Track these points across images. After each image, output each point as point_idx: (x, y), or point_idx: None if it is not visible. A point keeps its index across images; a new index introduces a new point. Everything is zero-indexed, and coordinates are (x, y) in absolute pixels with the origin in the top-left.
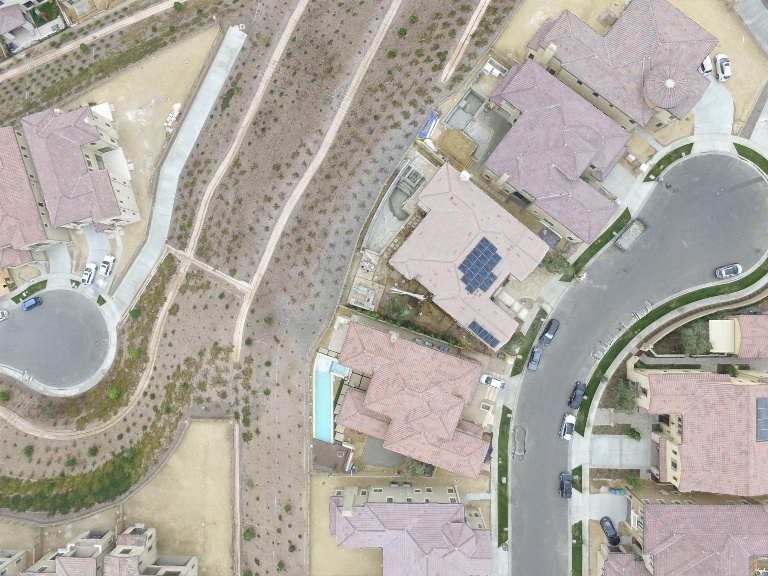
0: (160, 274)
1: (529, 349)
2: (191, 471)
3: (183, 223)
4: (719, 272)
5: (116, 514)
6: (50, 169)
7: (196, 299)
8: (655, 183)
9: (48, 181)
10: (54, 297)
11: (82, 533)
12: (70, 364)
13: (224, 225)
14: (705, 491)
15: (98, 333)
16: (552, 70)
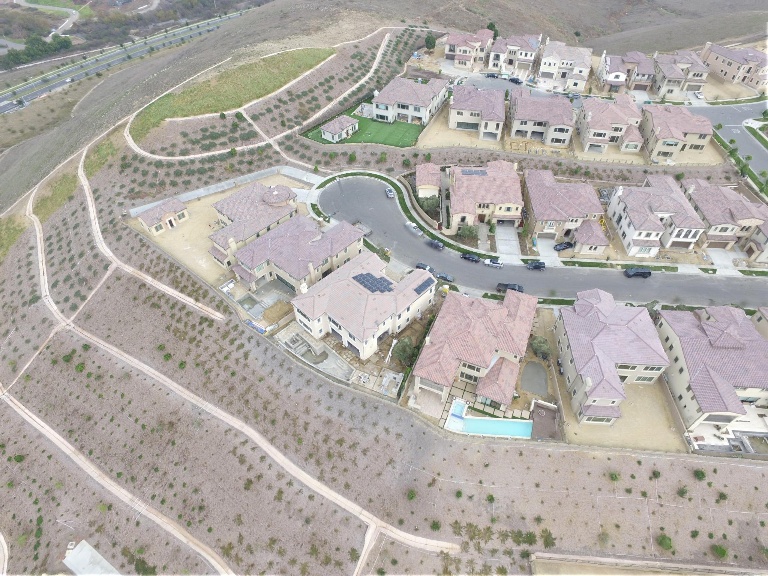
0: None
1: None
2: None
3: None
4: (390, 195)
5: None
6: None
7: None
8: (331, 219)
9: None
10: None
11: None
12: None
13: (295, 571)
14: None
15: None
16: None
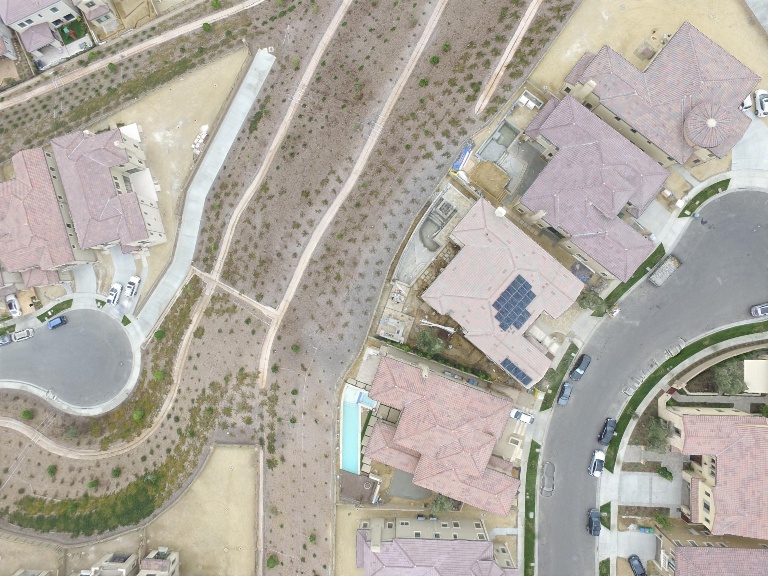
0: (185, 296)
1: (559, 384)
2: (215, 496)
3: (209, 245)
4: (755, 310)
5: (139, 537)
6: (79, 191)
7: (222, 323)
8: (690, 219)
9: (77, 203)
10: (79, 316)
11: (105, 555)
12: (94, 383)
13: (251, 249)
14: (739, 535)
15: (122, 353)
16: (589, 104)
